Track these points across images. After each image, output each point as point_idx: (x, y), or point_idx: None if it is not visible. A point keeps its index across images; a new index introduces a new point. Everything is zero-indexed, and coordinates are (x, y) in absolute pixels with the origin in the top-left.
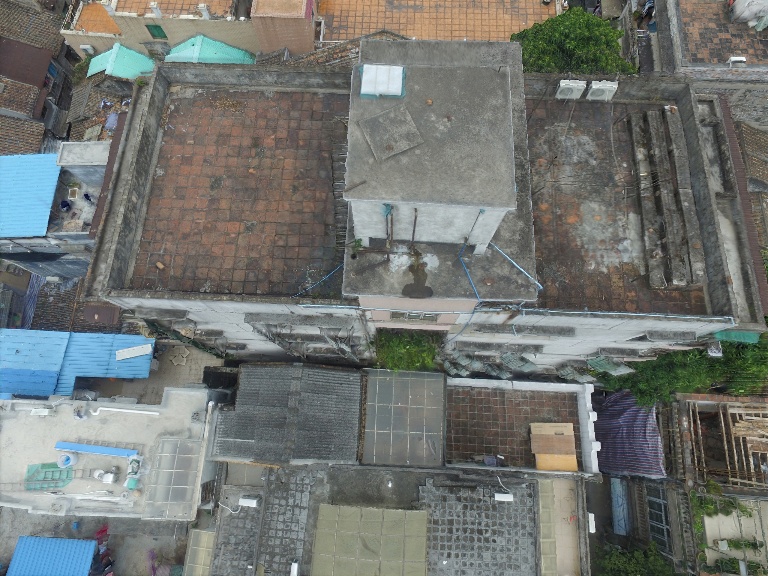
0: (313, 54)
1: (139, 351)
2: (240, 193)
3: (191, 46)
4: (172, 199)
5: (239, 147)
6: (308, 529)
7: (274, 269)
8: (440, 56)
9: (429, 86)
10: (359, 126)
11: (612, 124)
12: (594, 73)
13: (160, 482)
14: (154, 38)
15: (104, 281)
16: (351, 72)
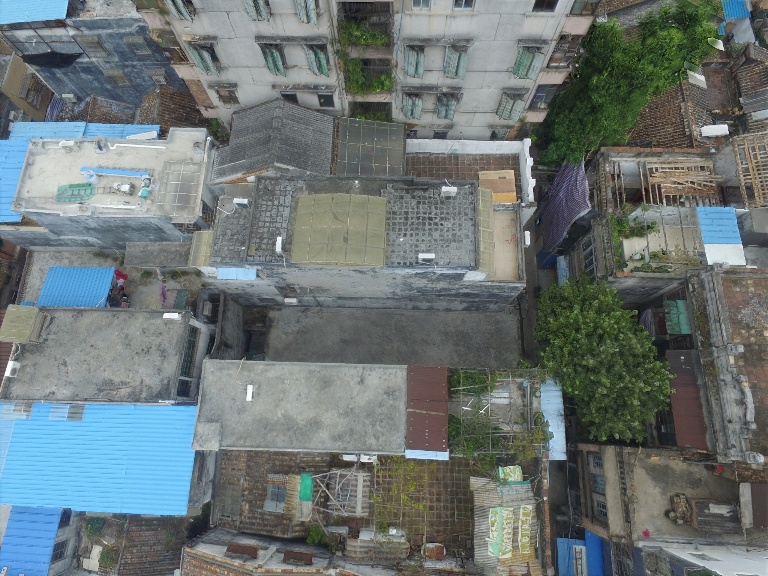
0: None
1: (146, 136)
2: None
3: None
4: None
5: None
6: (290, 221)
7: None
8: None
9: None
10: None
11: None
12: None
13: (168, 192)
14: None
15: None
16: None
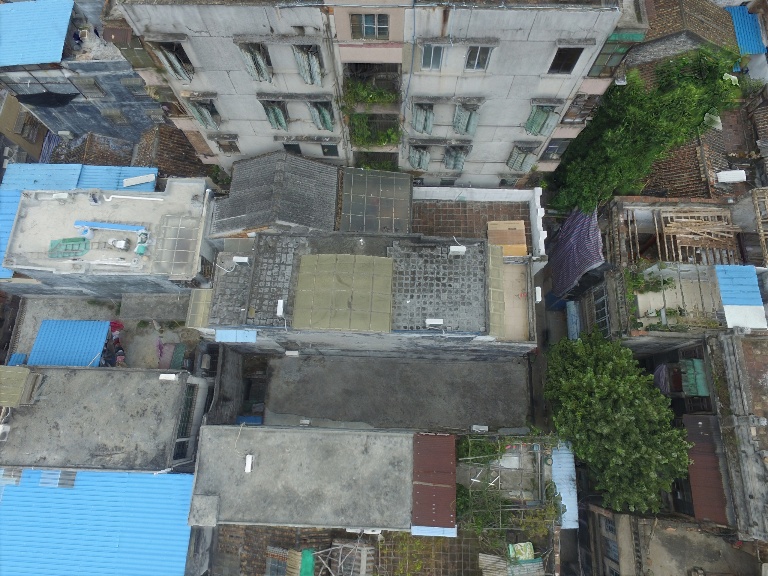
0: None
1: (144, 179)
2: None
3: None
4: None
5: None
6: (292, 281)
7: None
8: None
9: None
10: None
11: None
12: None
13: (165, 248)
14: None
15: None
16: None
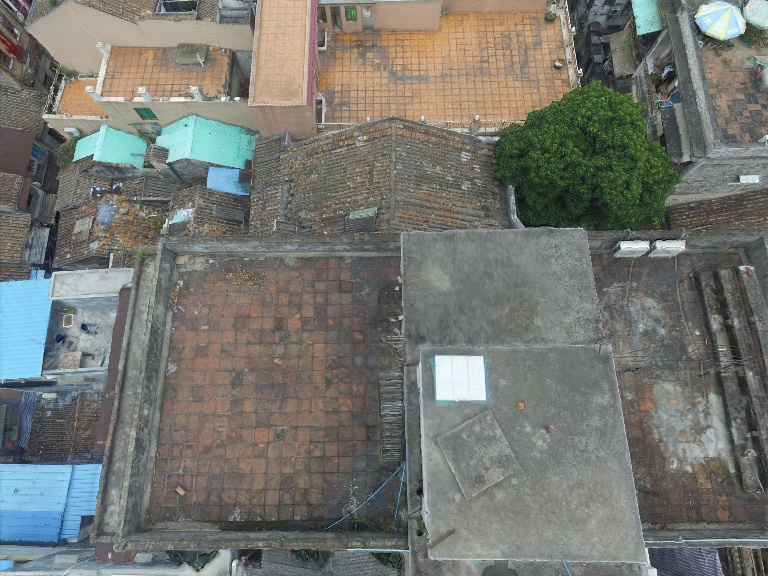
0: (317, 140)
1: None
2: (266, 390)
3: (184, 127)
4: (188, 402)
5: (260, 331)
6: None
7: (312, 487)
8: (495, 250)
9: (517, 379)
10: (437, 445)
11: (678, 281)
12: (622, 159)
13: None
14: (143, 119)
15: (118, 530)
16: (383, 240)
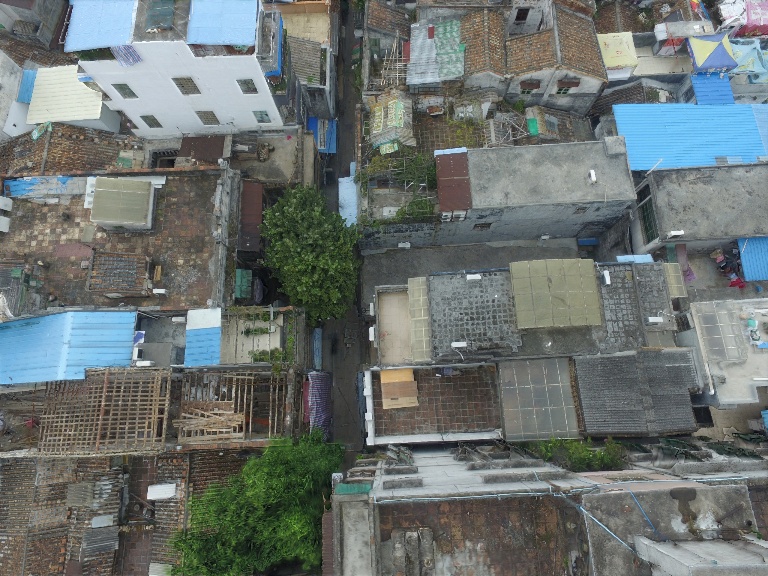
0: None
1: None
2: None
3: None
4: None
5: None
6: (602, 307)
7: None
8: None
9: None
10: None
11: None
12: None
13: (730, 327)
14: None
15: None
16: None
